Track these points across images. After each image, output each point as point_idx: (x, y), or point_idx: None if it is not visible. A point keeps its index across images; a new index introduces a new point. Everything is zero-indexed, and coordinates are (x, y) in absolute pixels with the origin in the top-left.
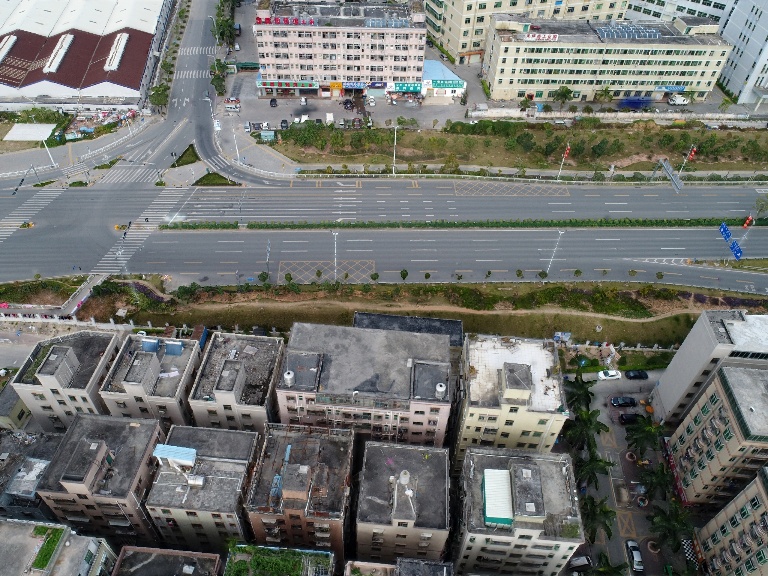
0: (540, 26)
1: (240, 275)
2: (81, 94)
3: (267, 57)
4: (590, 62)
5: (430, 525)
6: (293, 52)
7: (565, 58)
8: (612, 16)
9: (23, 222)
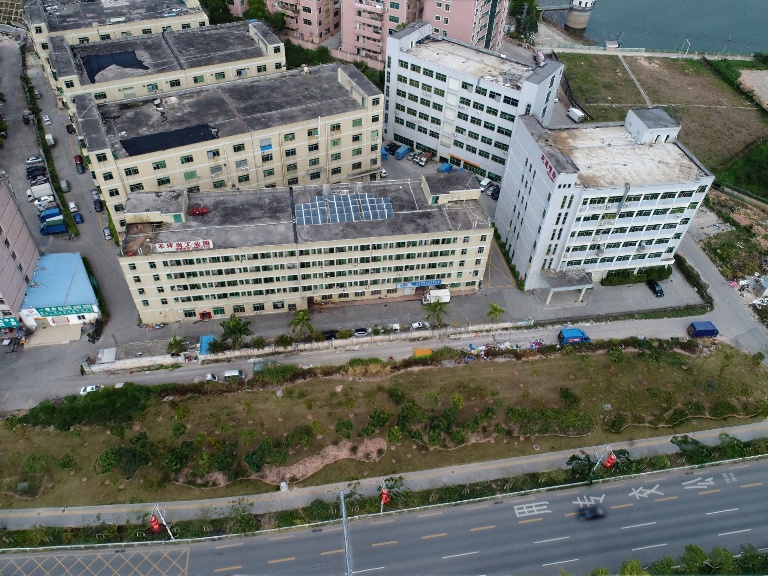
0: (211, 206)
1: None
2: None
3: None
4: (280, 267)
5: None
6: None
7: (237, 266)
8: (361, 150)
9: None
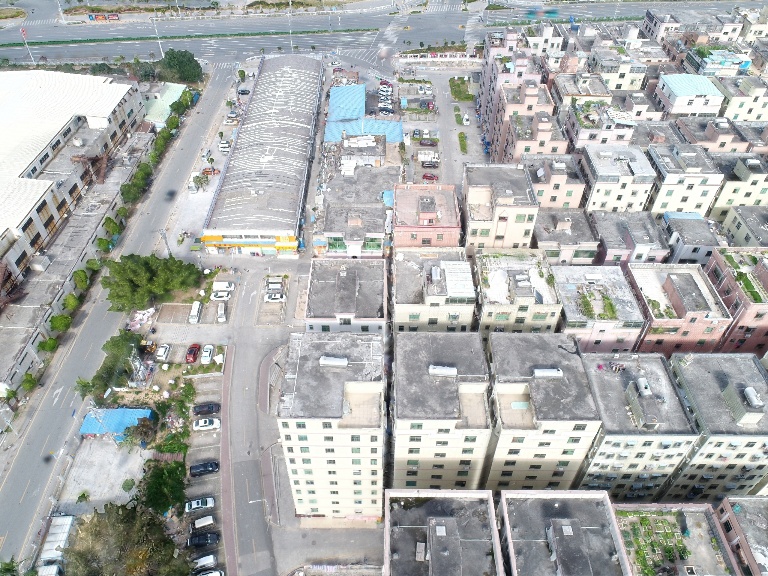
0: None
1: None
2: None
3: None
4: None
5: None
6: None
7: None
8: None
9: (401, 28)
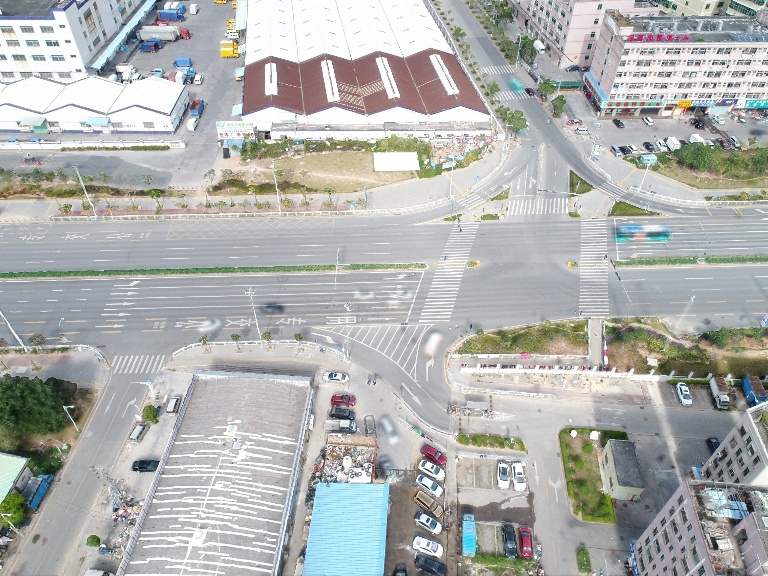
0: None
1: (741, 316)
2: (429, 120)
3: (624, 76)
4: None
5: None
6: (653, 70)
7: None
8: None
9: (465, 260)
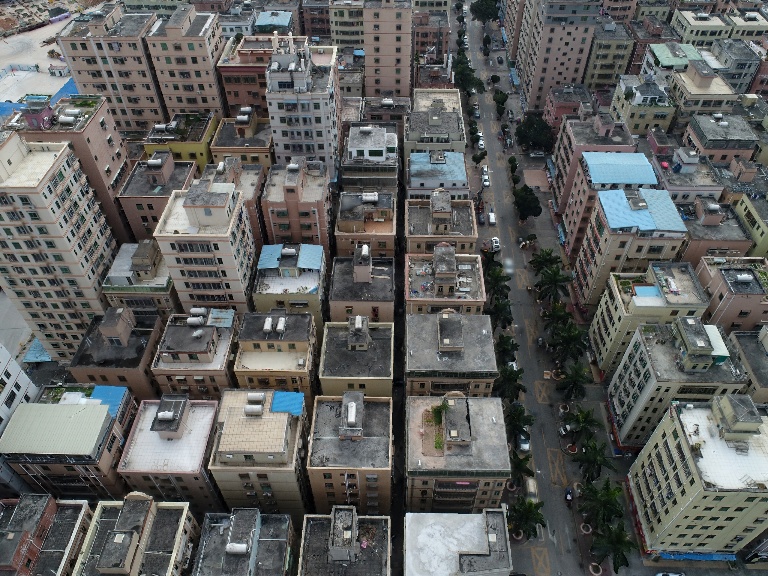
0: None
1: None
2: None
3: None
4: None
5: (746, 338)
6: None
7: None
8: None
9: None
